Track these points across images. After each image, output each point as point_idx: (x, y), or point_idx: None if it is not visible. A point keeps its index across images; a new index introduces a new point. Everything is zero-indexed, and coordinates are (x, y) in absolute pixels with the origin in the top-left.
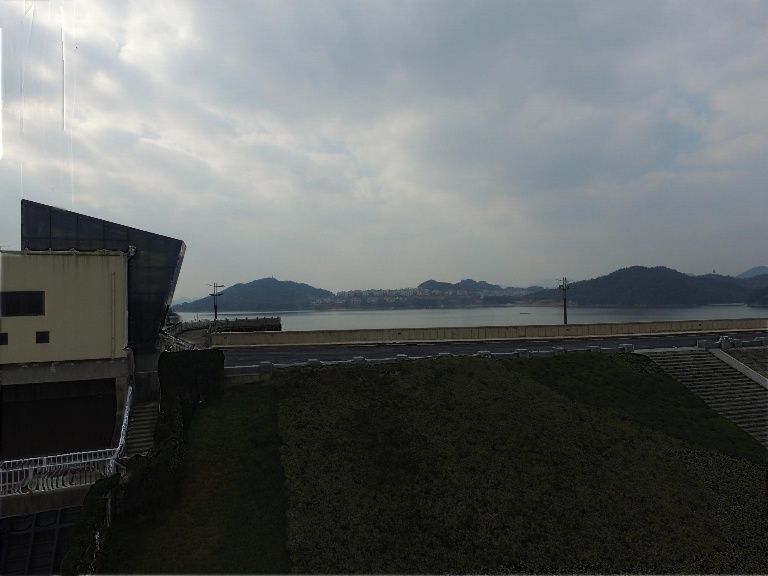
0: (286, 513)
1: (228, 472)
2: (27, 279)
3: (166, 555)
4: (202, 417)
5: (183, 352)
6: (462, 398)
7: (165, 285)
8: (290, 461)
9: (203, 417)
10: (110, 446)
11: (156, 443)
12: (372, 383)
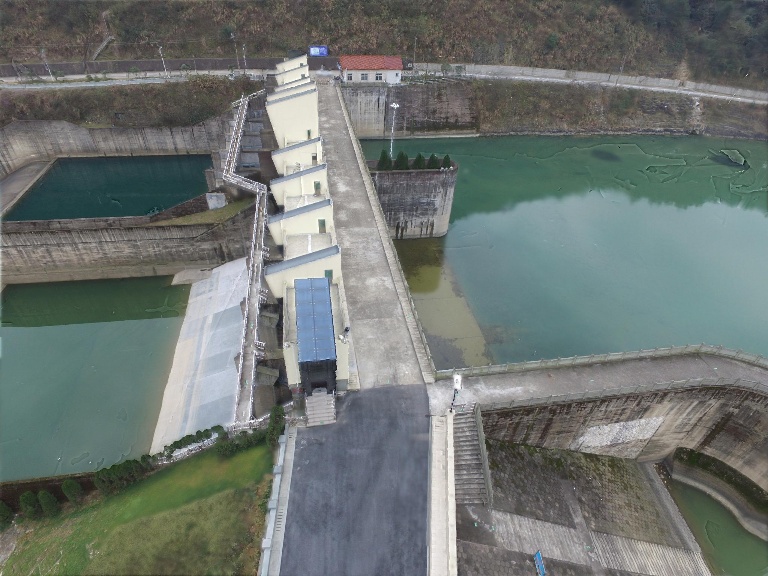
0: None
1: (218, 478)
2: None
3: None
4: (260, 450)
5: None
6: None
7: None
8: None
9: (259, 450)
10: None
11: None
12: None
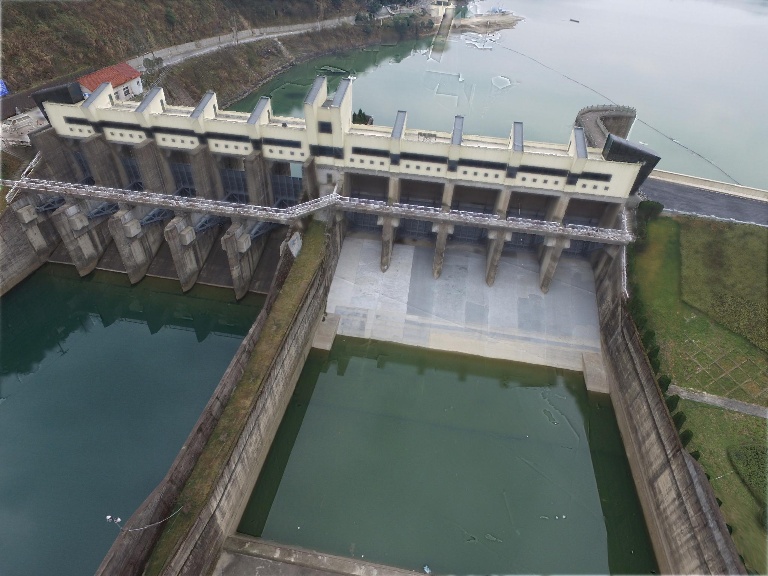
0: (681, 267)
1: (661, 248)
2: (609, 170)
3: (644, 265)
4: (651, 226)
5: (650, 203)
6: (750, 247)
7: (647, 172)
8: (684, 253)
9: (651, 226)
10: (619, 227)
11: (639, 233)
12: (716, 229)
